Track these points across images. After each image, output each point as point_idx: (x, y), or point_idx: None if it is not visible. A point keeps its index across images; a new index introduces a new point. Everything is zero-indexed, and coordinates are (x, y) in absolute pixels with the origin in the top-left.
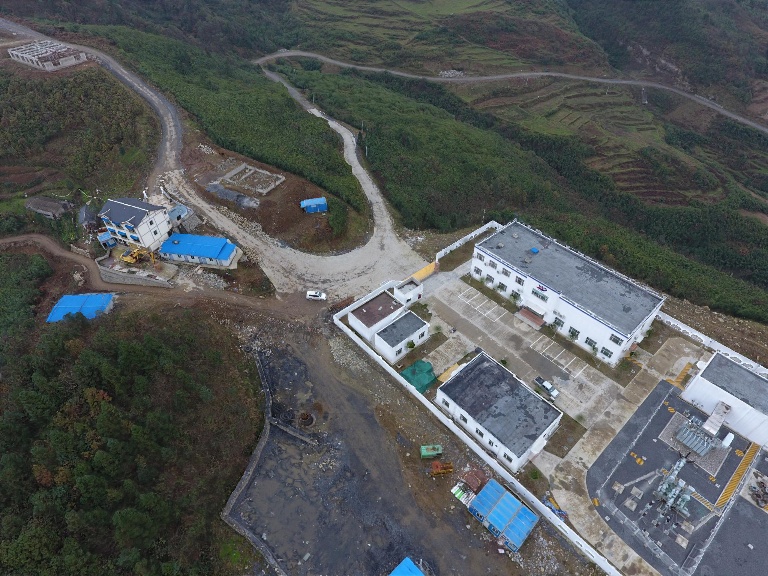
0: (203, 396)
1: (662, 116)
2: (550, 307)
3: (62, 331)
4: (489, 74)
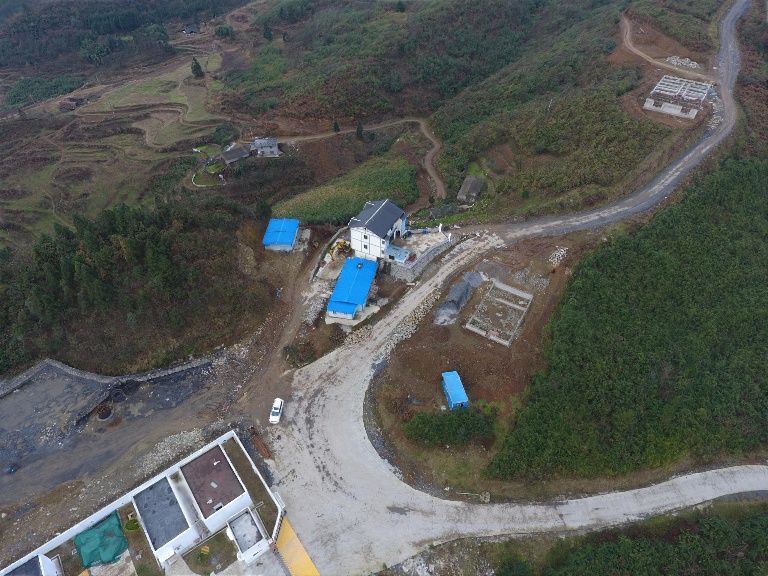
0: None
1: None
2: None
3: (189, 215)
4: None
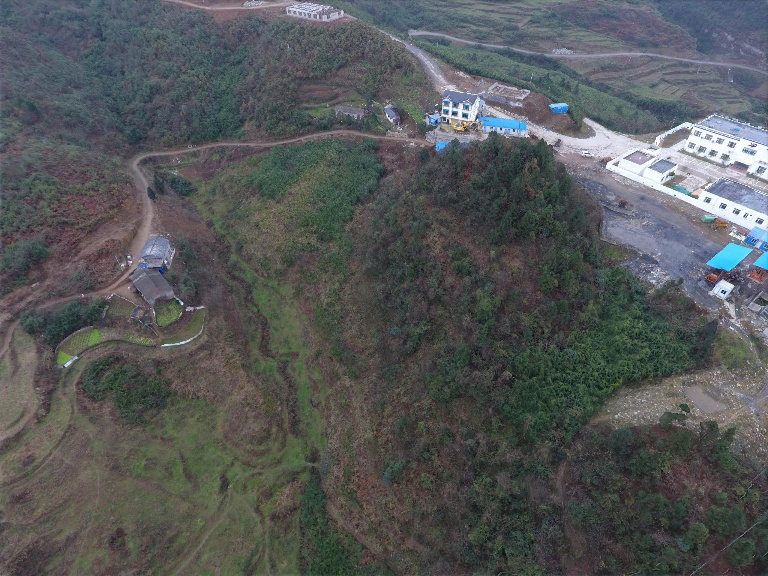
0: (573, 180)
1: (747, 93)
2: (757, 158)
3: None
4: (595, 53)
